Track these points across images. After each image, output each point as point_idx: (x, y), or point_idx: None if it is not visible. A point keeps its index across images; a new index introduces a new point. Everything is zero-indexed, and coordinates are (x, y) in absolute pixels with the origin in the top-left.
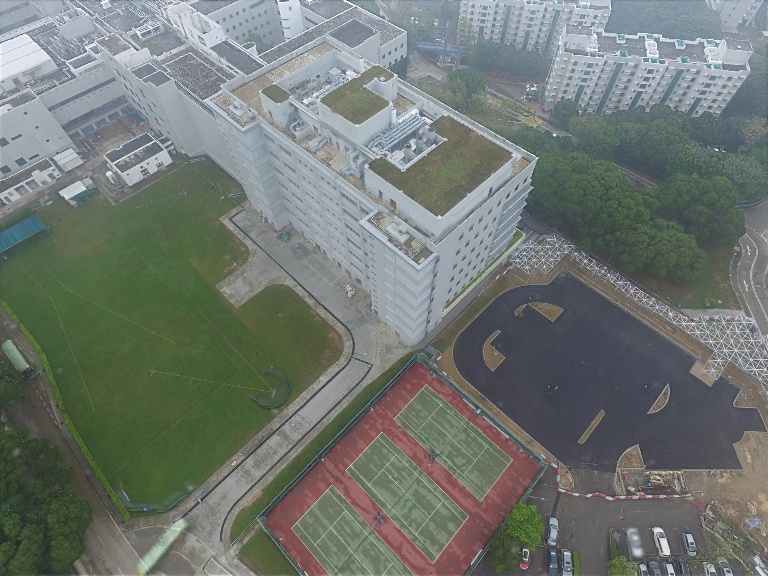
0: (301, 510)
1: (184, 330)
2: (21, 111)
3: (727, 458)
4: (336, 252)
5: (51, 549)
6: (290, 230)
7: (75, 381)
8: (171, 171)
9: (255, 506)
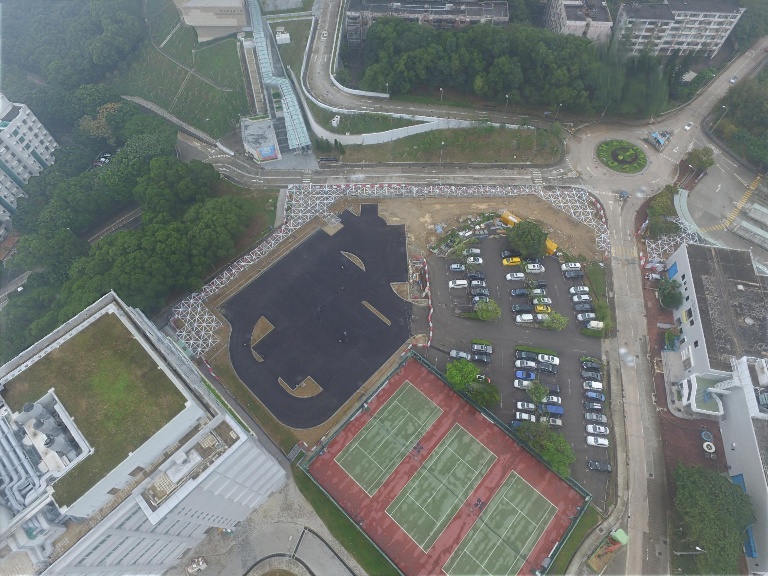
0: None
1: None
2: None
3: (397, 231)
4: None
5: None
6: None
7: None
8: None
9: None
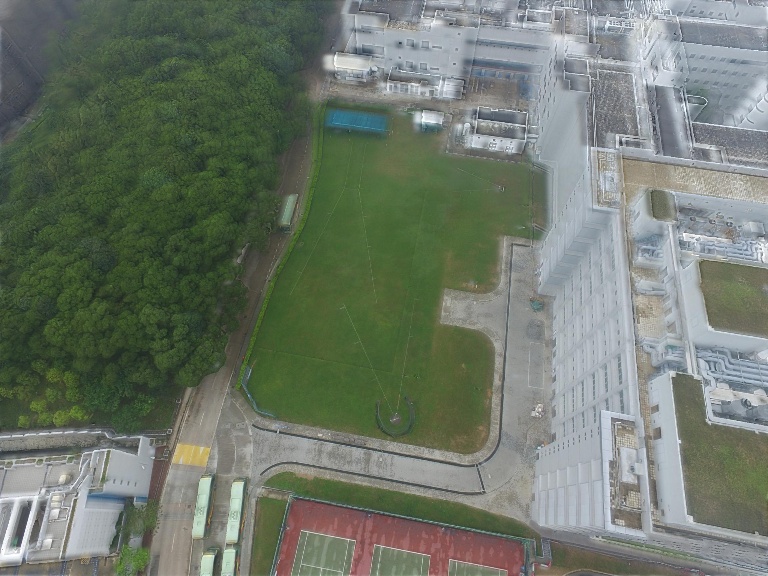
0: (319, 527)
1: (392, 299)
2: (458, 30)
3: None
4: (563, 369)
5: (183, 367)
6: (548, 303)
7: (301, 261)
8: (512, 160)
9: (300, 482)
